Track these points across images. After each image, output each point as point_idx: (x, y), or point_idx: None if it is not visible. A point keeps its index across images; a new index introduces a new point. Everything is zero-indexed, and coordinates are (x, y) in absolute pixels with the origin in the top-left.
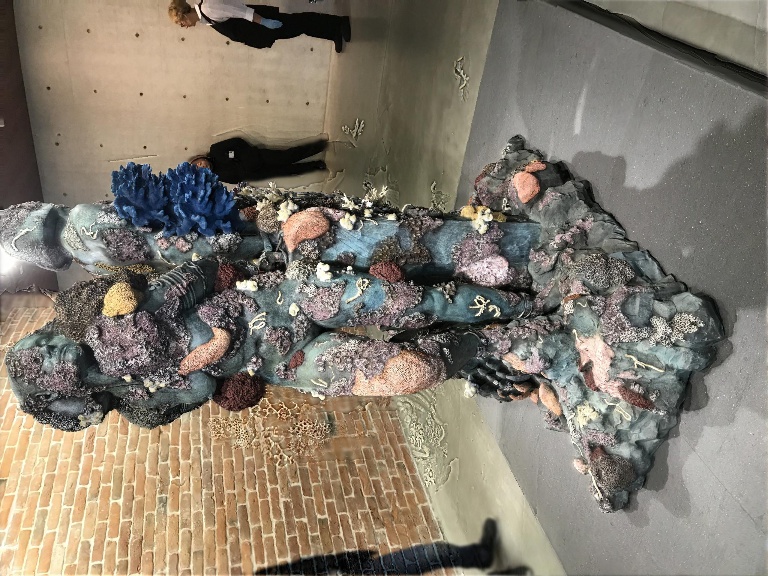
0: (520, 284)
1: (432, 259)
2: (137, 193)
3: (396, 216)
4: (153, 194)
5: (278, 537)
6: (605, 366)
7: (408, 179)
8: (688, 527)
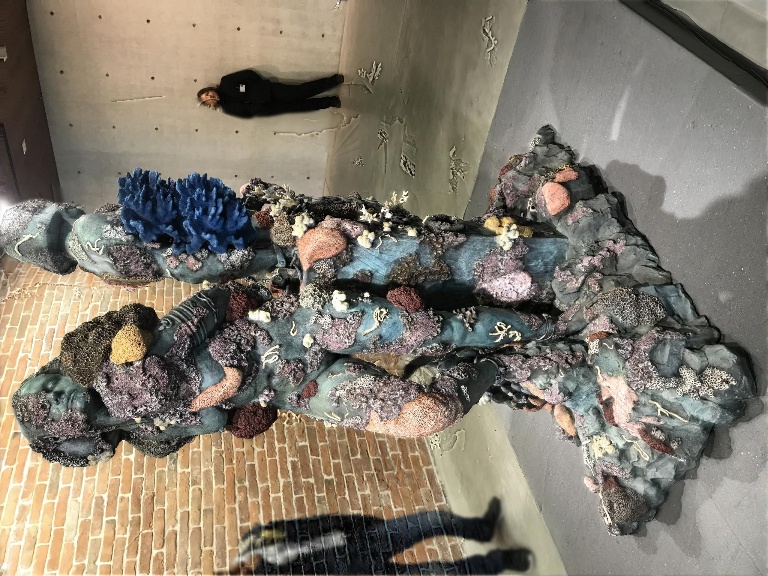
0: (542, 299)
1: (452, 276)
2: (144, 207)
3: (417, 232)
4: (161, 208)
5: (285, 497)
6: (627, 409)
7: (426, 137)
8: (697, 568)
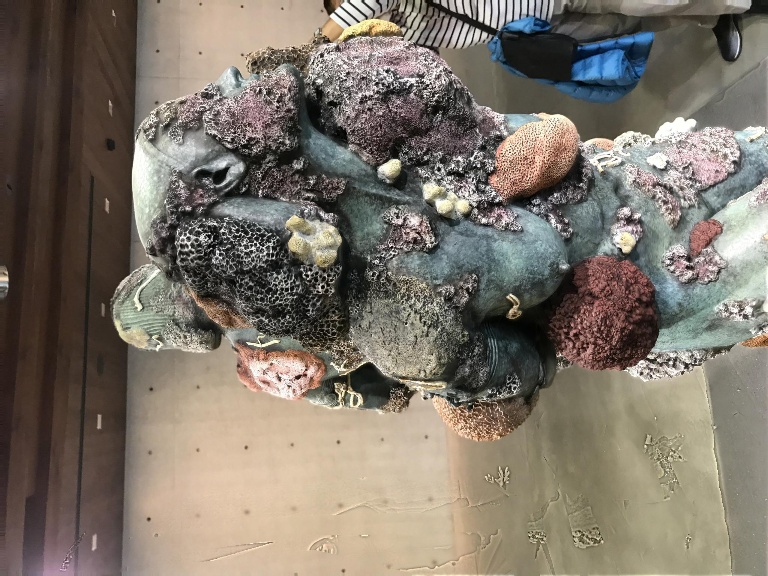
0: None
1: None
2: None
3: None
4: None
5: None
6: None
7: (600, 475)
8: None
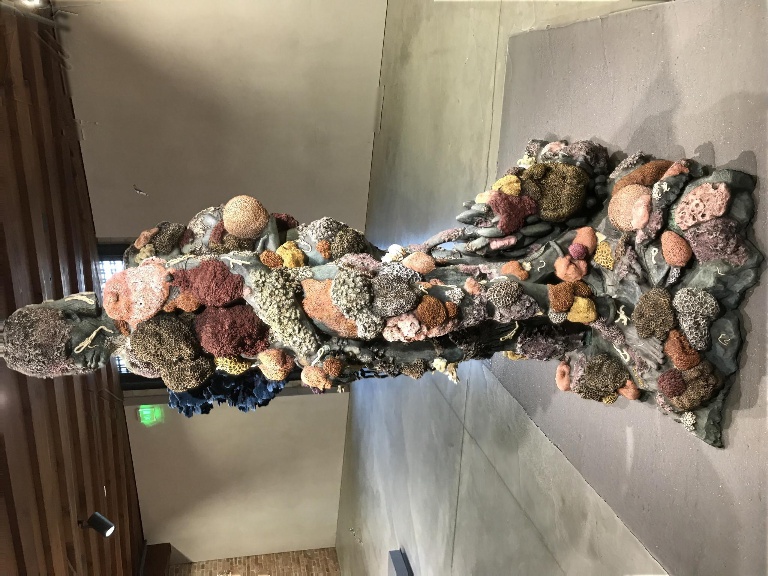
0: None
1: None
2: None
3: None
4: None
5: None
6: None
7: None
8: None
